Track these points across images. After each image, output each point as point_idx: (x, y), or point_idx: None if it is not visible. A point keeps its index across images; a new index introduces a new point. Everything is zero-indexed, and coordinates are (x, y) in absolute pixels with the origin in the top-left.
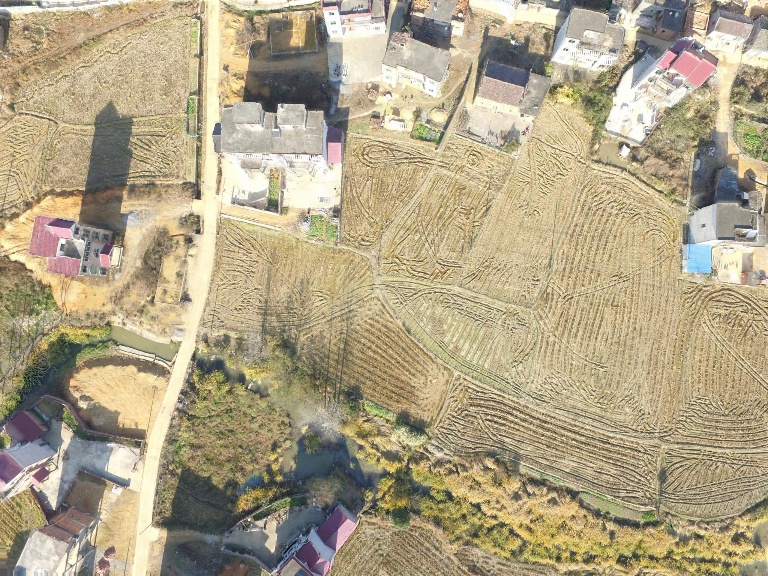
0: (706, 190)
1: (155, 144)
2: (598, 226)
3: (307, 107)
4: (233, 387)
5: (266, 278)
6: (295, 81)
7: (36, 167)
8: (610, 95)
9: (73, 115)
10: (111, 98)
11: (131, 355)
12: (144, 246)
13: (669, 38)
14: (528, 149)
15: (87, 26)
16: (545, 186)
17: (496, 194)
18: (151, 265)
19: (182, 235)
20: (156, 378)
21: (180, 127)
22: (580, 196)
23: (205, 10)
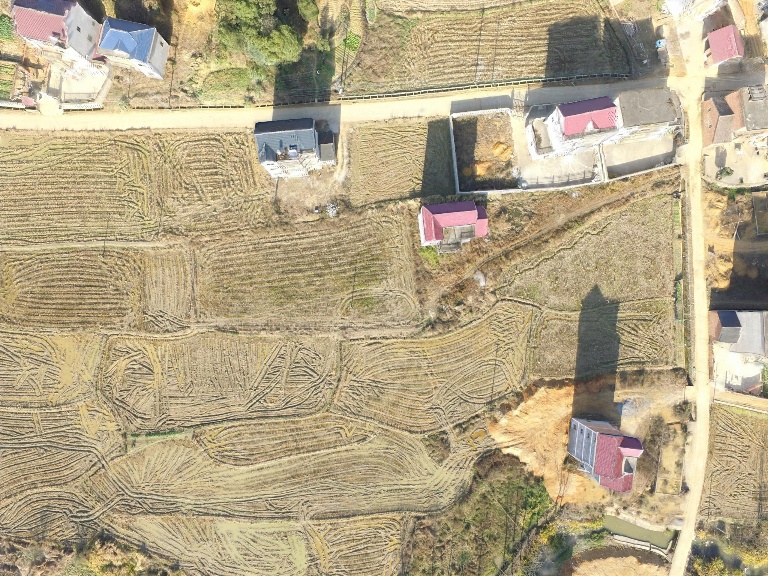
0: None
1: (642, 329)
2: None
3: None
4: (729, 572)
5: (759, 463)
6: None
7: (522, 356)
8: None
9: (557, 300)
10: (595, 282)
11: (626, 544)
12: (640, 436)
13: None
14: None
15: (566, 206)
16: None
17: None
18: (652, 456)
19: (678, 423)
20: (658, 568)
21: (666, 310)
22: None
23: (686, 188)
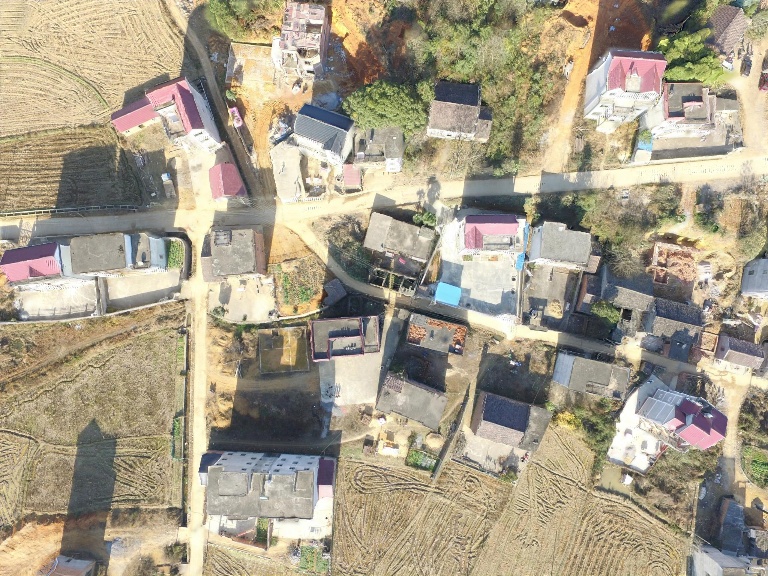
0: (711, 522)
1: (140, 466)
2: (599, 558)
3: (298, 431)
4: None
5: None
6: (285, 402)
7: (16, 489)
8: (613, 425)
9: (54, 434)
10: (94, 416)
11: None
12: None
13: (676, 360)
14: (527, 474)
15: (68, 339)
16: (544, 514)
17: (493, 524)
18: None
19: (168, 566)
20: None
21: (166, 448)
22: (581, 525)
23: (192, 324)
